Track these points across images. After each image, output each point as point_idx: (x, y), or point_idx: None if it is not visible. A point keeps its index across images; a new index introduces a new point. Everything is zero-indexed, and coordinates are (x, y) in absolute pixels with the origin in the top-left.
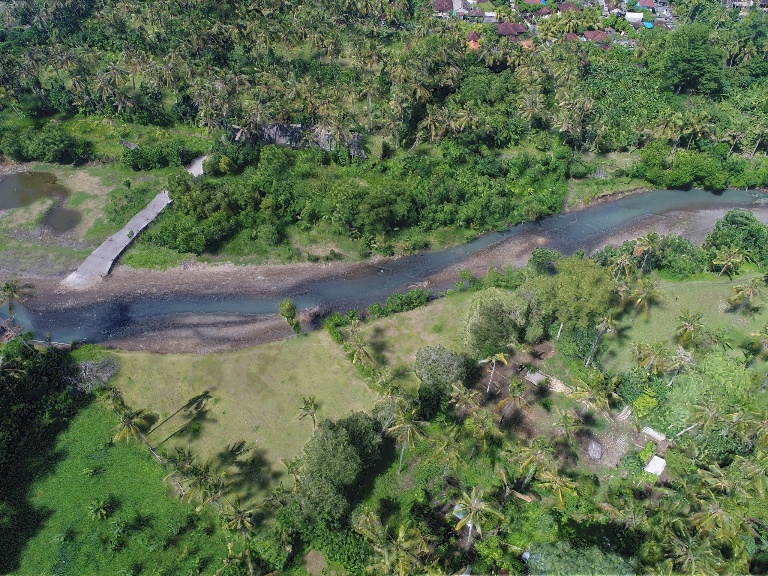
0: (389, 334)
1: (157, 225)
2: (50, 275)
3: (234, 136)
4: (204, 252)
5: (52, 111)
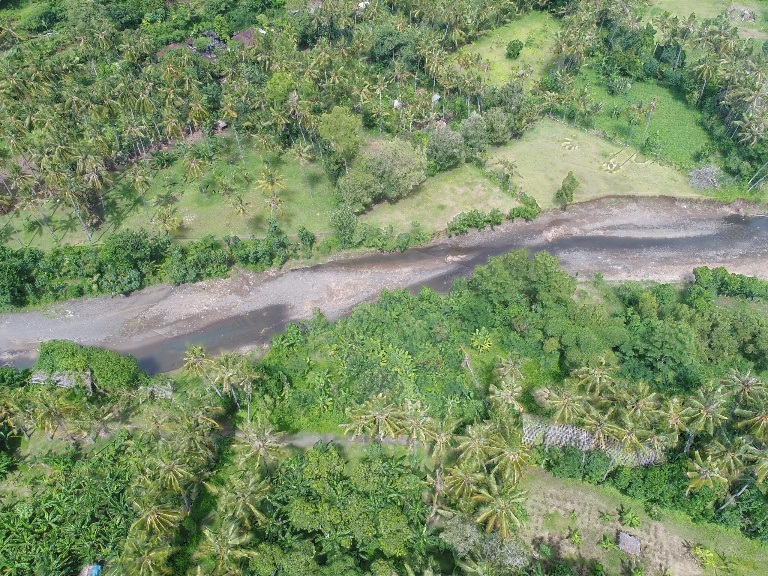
0: (482, 204)
1: None
2: None
3: None
4: None
5: None
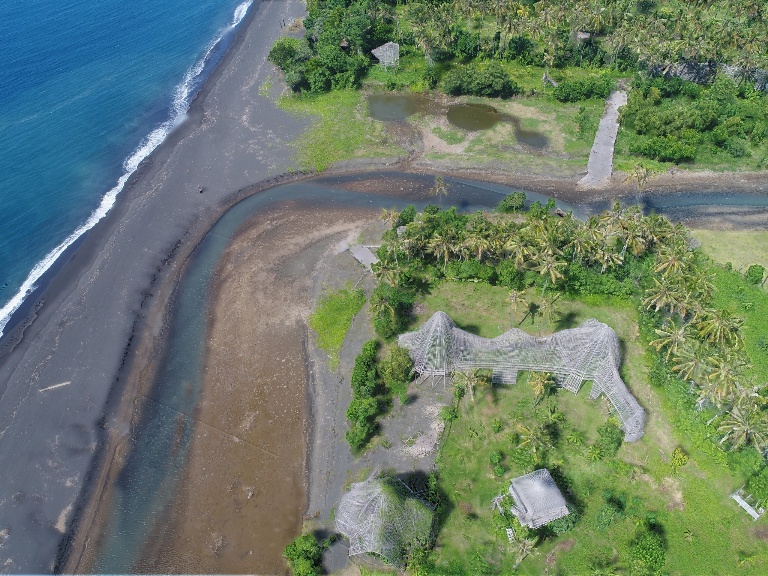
0: None
1: (621, 142)
2: (563, 177)
3: (656, 71)
4: (681, 162)
5: (449, 56)
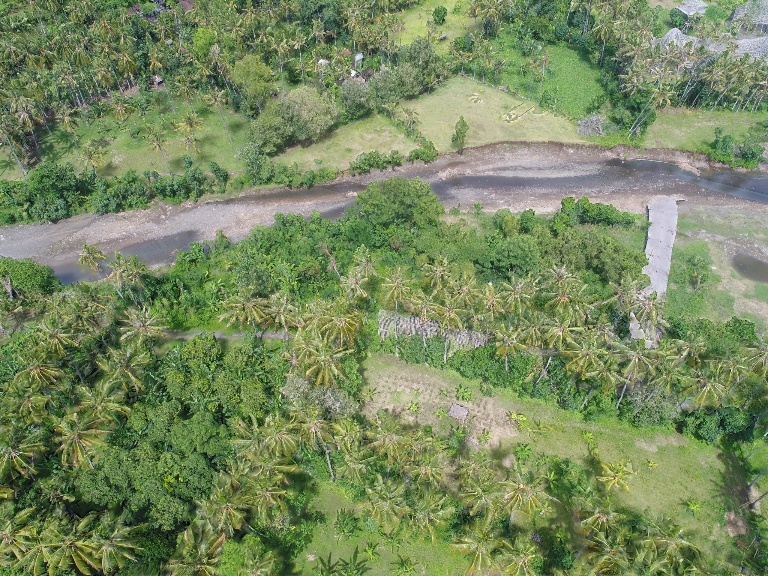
0: (386, 148)
1: None
2: None
3: None
4: None
5: None
